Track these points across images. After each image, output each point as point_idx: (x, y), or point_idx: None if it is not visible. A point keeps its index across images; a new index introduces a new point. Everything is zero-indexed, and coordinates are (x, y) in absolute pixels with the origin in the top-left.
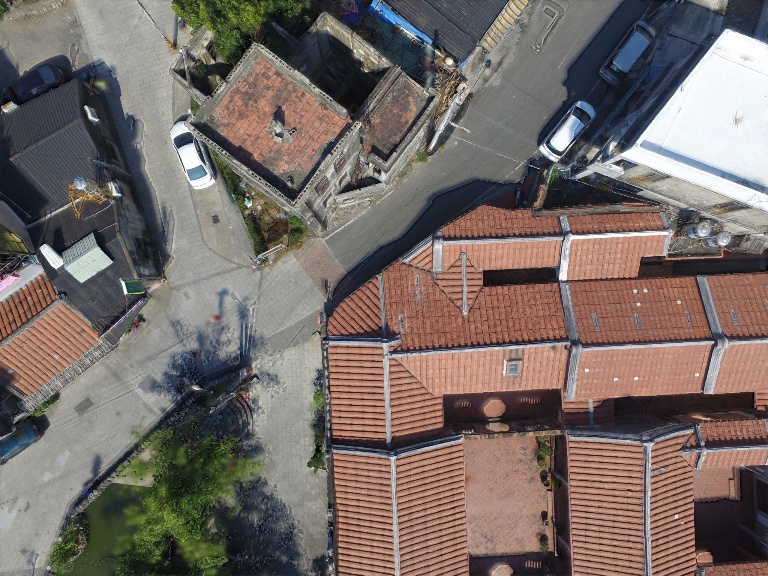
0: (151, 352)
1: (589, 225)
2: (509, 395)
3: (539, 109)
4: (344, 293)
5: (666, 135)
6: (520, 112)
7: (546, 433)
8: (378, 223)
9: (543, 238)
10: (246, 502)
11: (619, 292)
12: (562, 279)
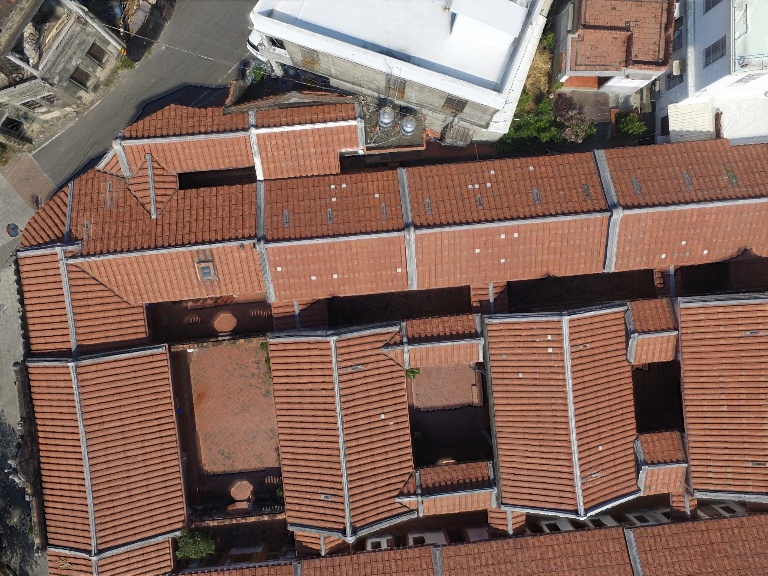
0: None
1: (277, 119)
2: (239, 308)
3: (249, 8)
4: None
5: (301, 5)
6: (229, 12)
7: (257, 340)
8: (87, 135)
9: (228, 134)
10: None
11: (316, 188)
12: (259, 178)
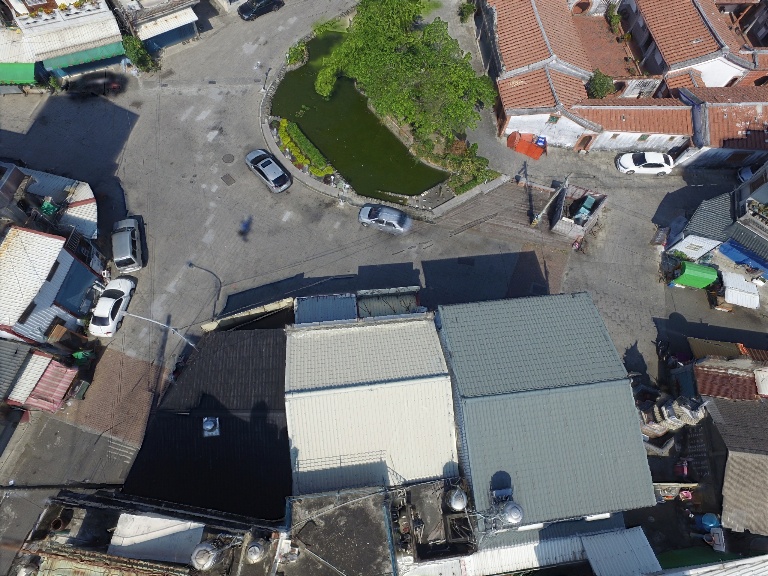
0: None
1: None
2: (582, 5)
3: None
4: None
5: None
6: None
7: None
8: None
9: None
10: None
11: None
12: None
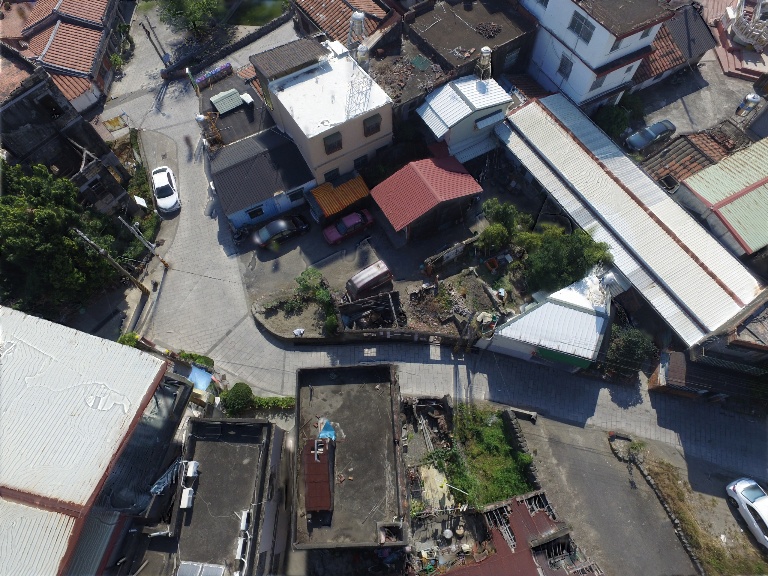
0: None
1: None
2: None
3: None
4: (86, 119)
5: None
6: None
7: None
8: None
9: None
10: (187, 23)
11: None
12: None
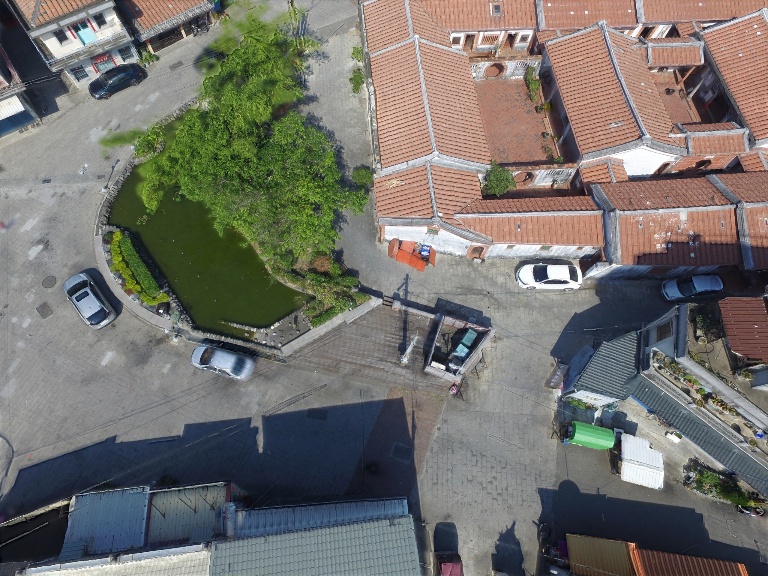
0: (231, 36)
1: None
2: None
3: None
4: None
5: None
6: None
7: (530, 57)
8: None
9: None
10: None
11: None
12: None
